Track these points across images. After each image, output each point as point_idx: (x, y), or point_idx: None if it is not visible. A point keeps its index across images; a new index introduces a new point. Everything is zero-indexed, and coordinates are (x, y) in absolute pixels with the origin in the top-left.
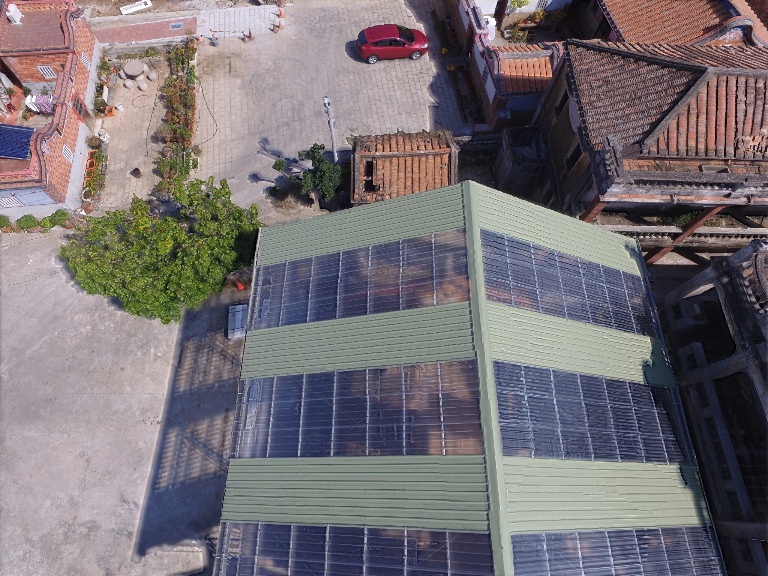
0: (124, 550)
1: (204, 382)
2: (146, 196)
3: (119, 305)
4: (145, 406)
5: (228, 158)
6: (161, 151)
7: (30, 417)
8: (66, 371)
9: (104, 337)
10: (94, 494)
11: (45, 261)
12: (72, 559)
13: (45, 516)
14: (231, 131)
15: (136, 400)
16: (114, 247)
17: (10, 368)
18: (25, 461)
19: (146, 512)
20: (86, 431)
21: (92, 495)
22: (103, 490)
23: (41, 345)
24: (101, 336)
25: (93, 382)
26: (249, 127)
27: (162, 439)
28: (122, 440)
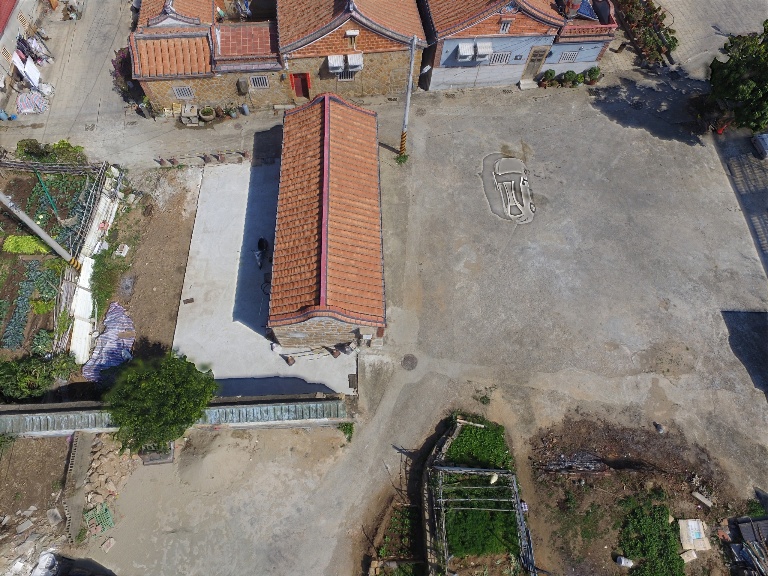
0: (765, 286)
1: (757, 186)
2: (632, 66)
3: (661, 136)
4: (723, 200)
5: (695, 37)
6: (624, 35)
7: (642, 205)
8: (649, 177)
9: (664, 156)
10: (721, 253)
11: (585, 107)
12: (731, 291)
13: (694, 265)
14: (686, 19)
15: (714, 196)
16: (760, 60)
17: (605, 174)
18: (657, 232)
19: (766, 264)
20: (689, 214)
21: (720, 253)
22: (726, 250)
23: (619, 160)
24: (661, 155)
25: (674, 184)
26: (698, 16)
27: (749, 220)
28: (720, 220)
